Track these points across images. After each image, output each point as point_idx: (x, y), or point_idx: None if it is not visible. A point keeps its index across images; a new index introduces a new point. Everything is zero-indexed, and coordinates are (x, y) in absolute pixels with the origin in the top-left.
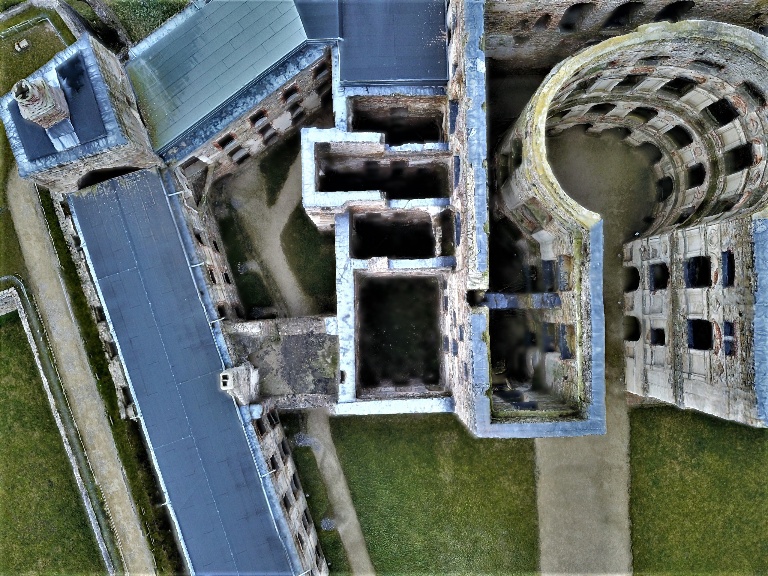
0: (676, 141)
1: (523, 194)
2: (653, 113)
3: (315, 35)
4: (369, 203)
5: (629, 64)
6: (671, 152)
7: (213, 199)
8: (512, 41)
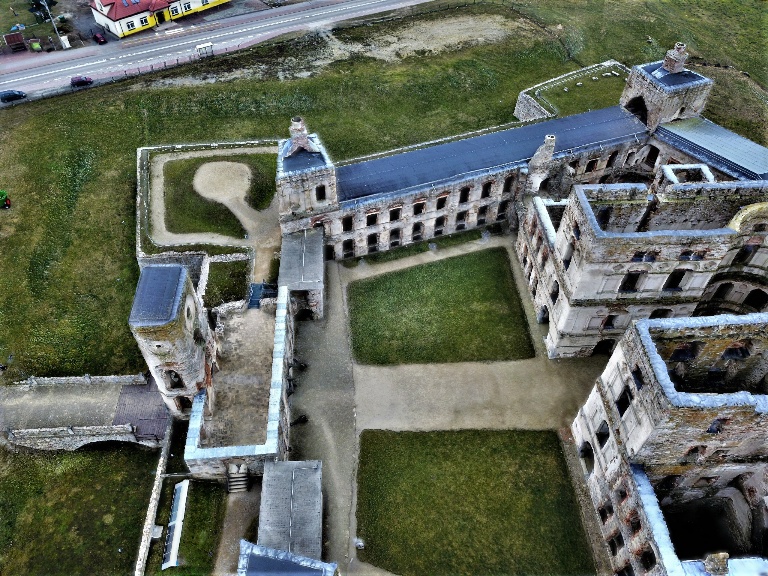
0: None
1: None
2: None
3: (763, 177)
4: None
5: None
6: None
7: None
8: None
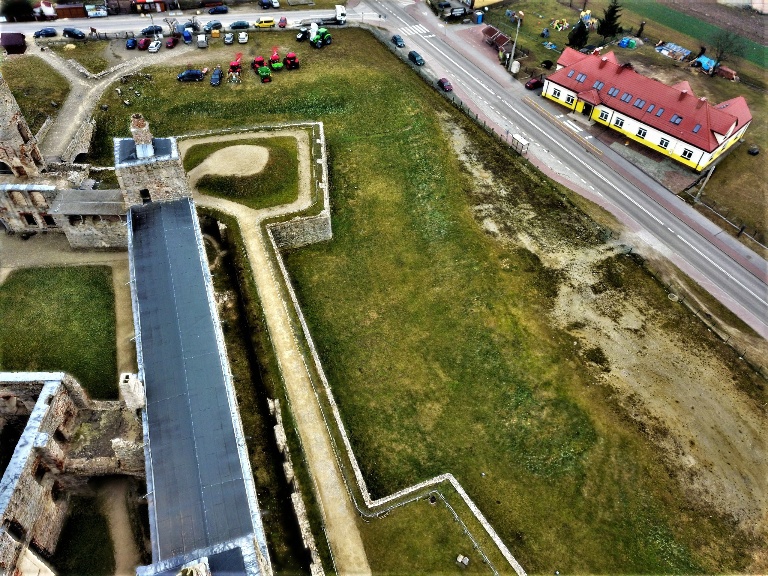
0: None
1: None
2: None
3: None
4: None
5: None
6: None
7: None
8: None
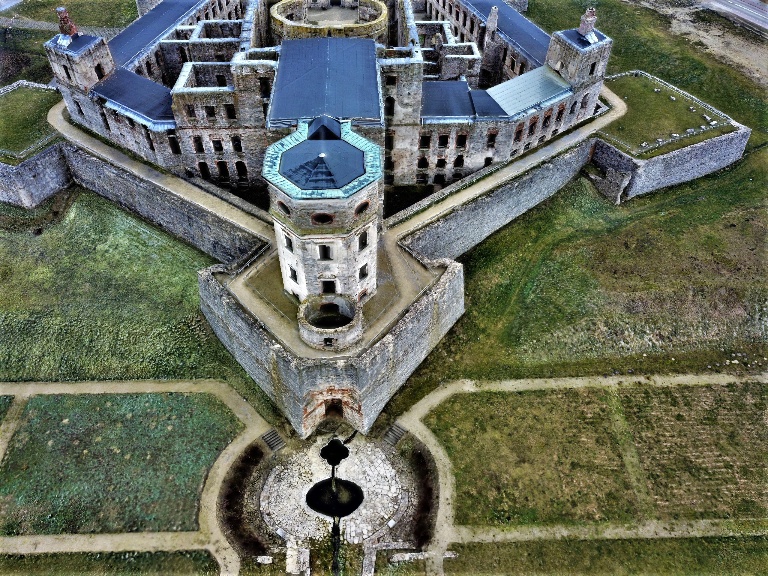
0: None
1: None
2: None
3: (482, 91)
4: None
5: None
6: None
7: None
8: None
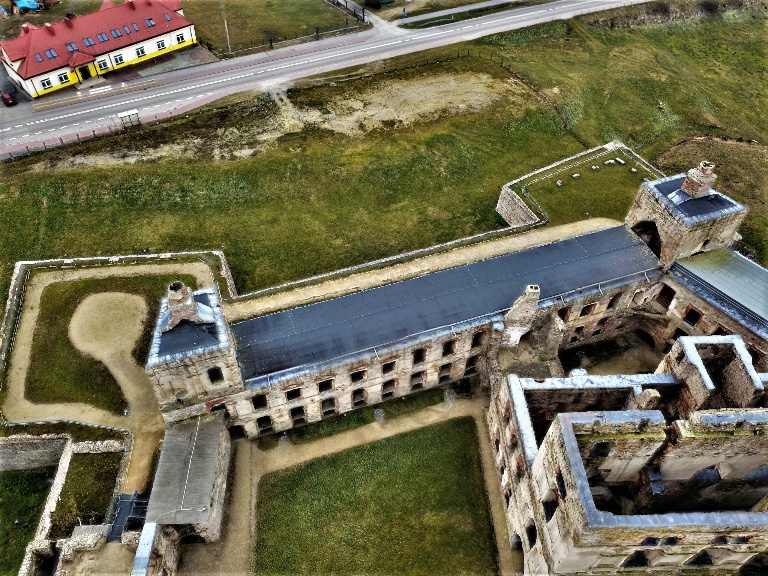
0: None
1: None
2: None
3: None
4: (697, 391)
5: None
6: None
7: (629, 337)
8: None
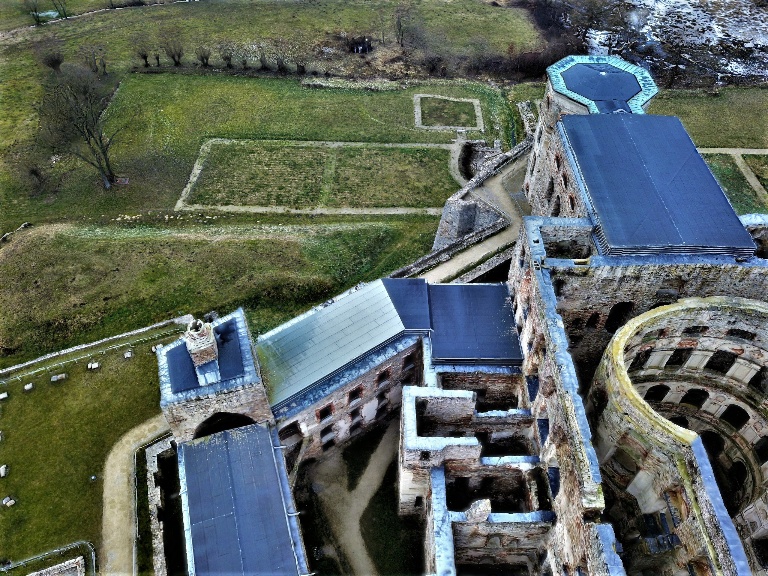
0: (733, 423)
1: (614, 432)
2: (705, 395)
3: (411, 327)
4: (465, 454)
5: (676, 335)
6: (732, 435)
7: (295, 483)
8: (568, 340)
